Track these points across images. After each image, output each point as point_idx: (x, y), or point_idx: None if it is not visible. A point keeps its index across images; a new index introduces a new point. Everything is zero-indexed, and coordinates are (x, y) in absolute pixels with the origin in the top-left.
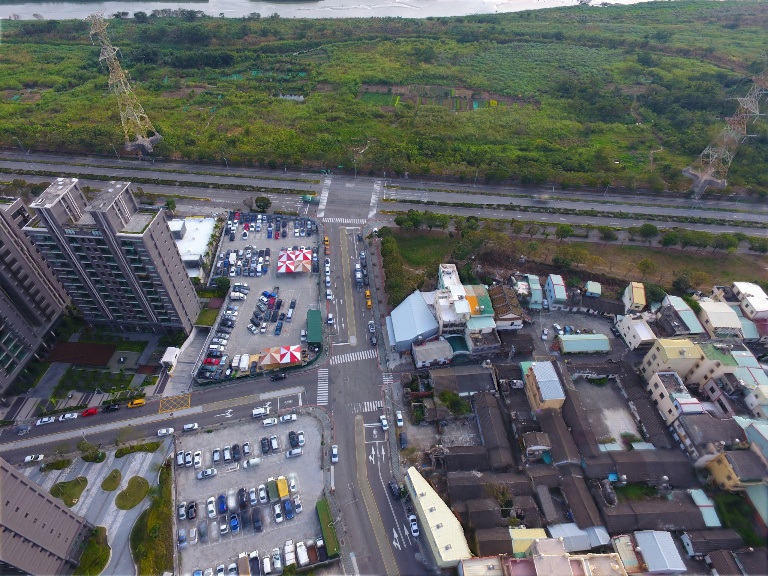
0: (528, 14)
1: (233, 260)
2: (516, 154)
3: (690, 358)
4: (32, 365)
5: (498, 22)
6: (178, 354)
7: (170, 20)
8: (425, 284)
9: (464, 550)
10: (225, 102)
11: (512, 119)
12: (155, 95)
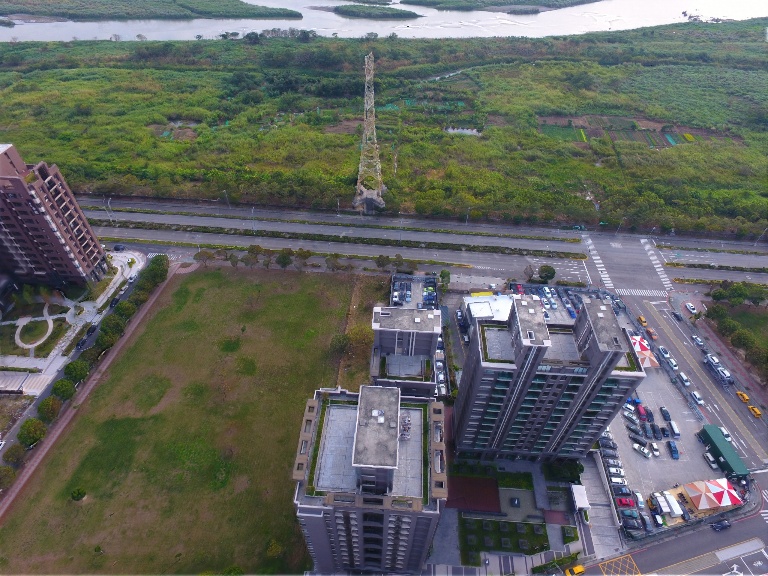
0: (652, 32)
1: None
2: (764, 201)
3: None
4: None
5: (630, 42)
6: None
7: (283, 41)
8: None
9: None
10: (400, 138)
11: (727, 157)
12: (319, 130)
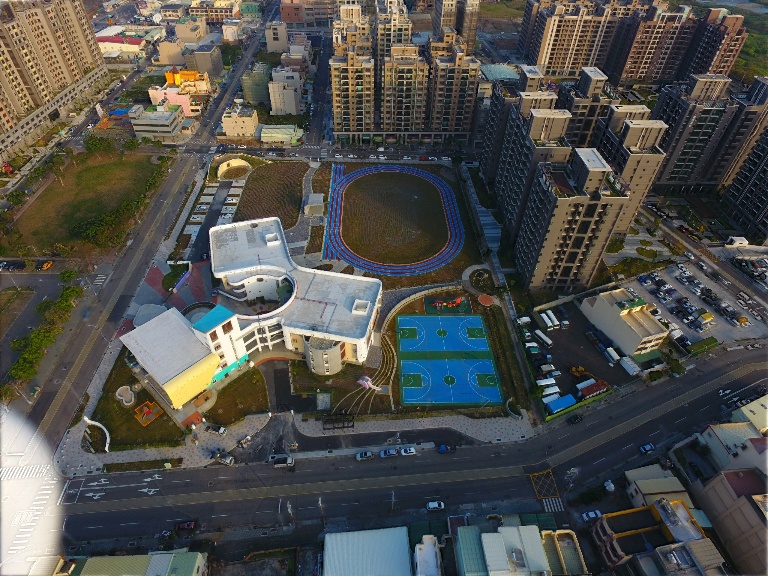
0: None
1: None
2: None
3: None
4: (677, 188)
5: None
6: (743, 245)
7: None
8: None
9: (759, 424)
10: None
11: None
12: None
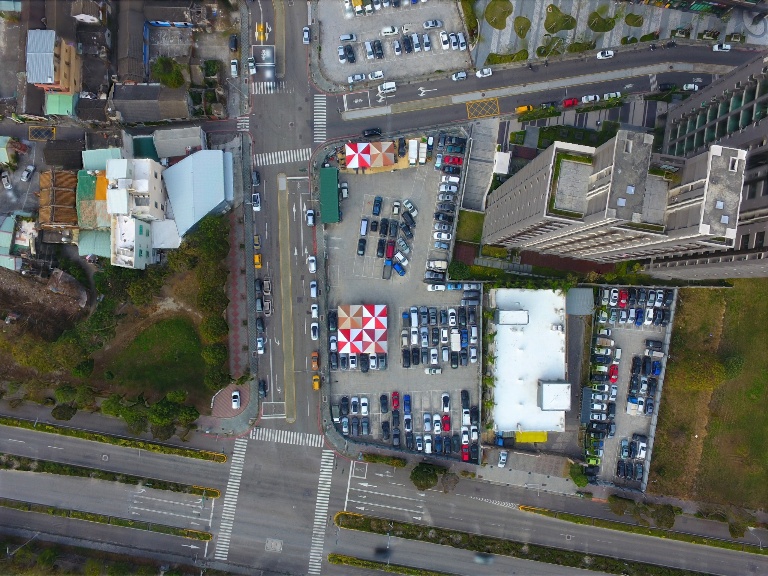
0: None
1: (454, 335)
2: None
3: None
4: None
5: None
6: None
7: None
8: (174, 278)
9: None
10: None
11: None
12: None
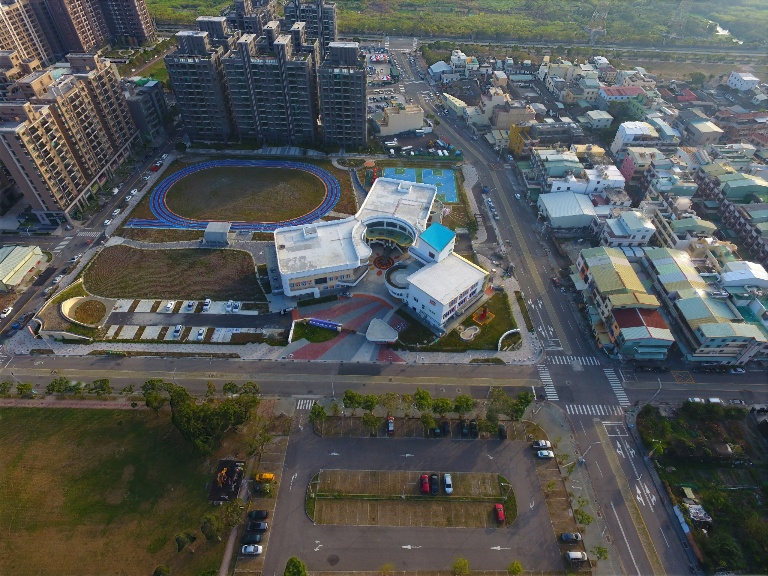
0: None
1: None
2: None
3: (562, 67)
4: None
5: None
6: None
7: None
8: None
9: (465, 105)
10: None
11: (493, 19)
12: None
